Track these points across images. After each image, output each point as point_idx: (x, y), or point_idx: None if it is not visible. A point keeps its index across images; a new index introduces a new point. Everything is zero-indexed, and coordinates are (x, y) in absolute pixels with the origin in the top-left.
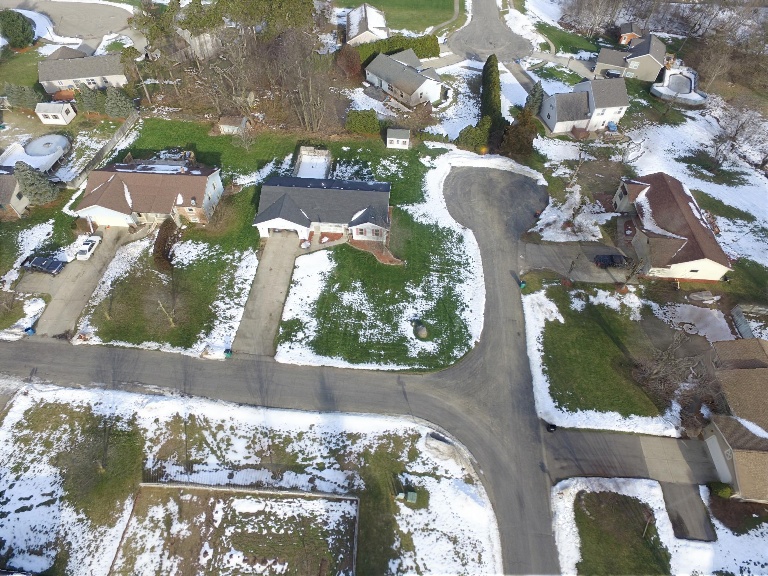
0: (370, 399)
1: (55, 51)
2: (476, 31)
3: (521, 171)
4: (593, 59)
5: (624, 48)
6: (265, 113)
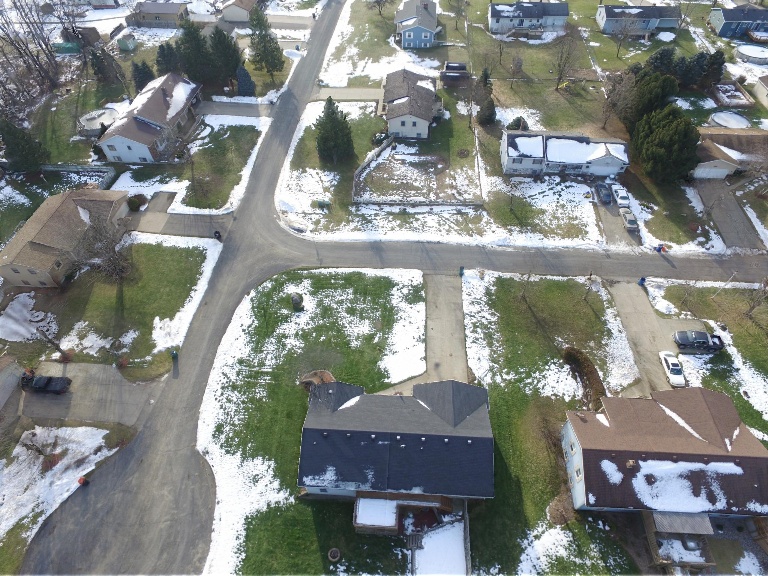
0: (344, 249)
1: None
2: None
3: None
4: None
5: None
6: None
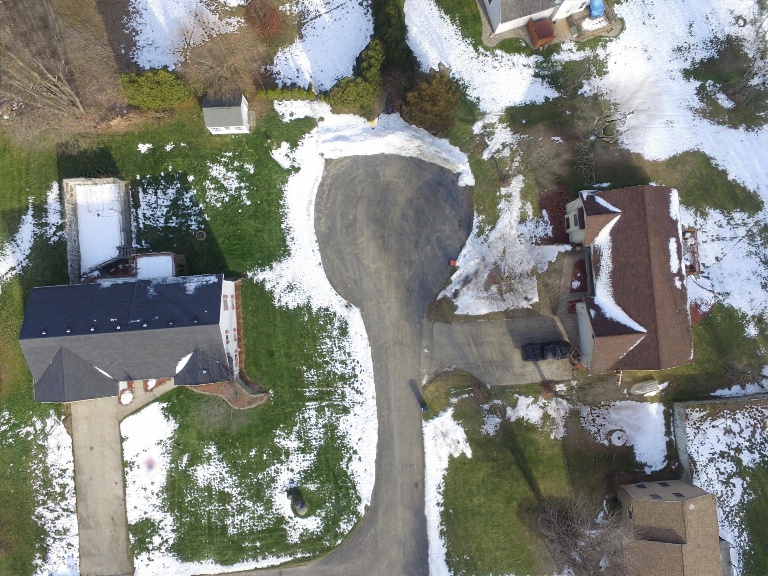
0: None
1: None
2: None
3: (434, 159)
4: None
5: None
6: None
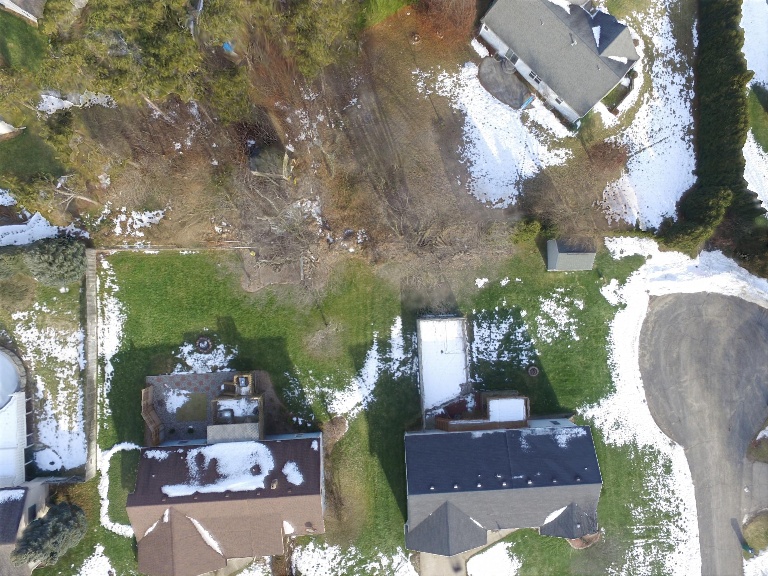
0: None
1: None
2: None
3: (757, 300)
4: None
5: None
6: (320, 197)
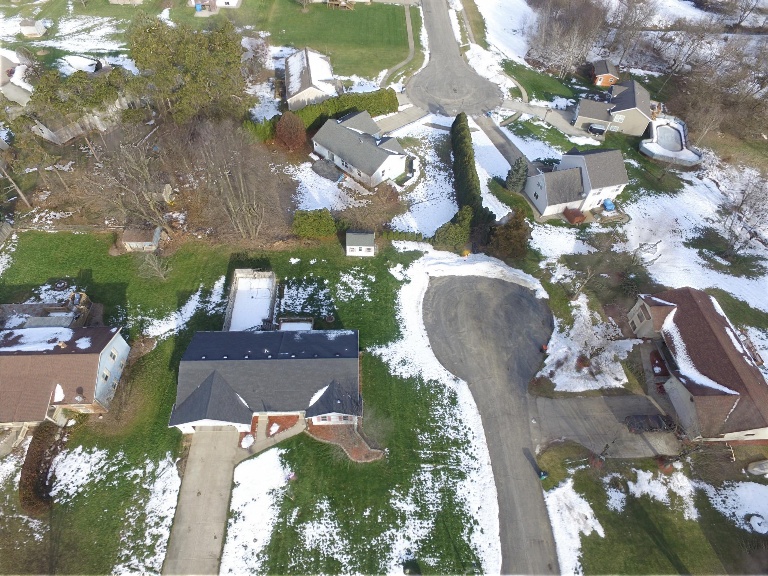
0: None
1: None
2: (437, 74)
3: (514, 279)
4: (571, 108)
5: (601, 91)
6: (187, 211)
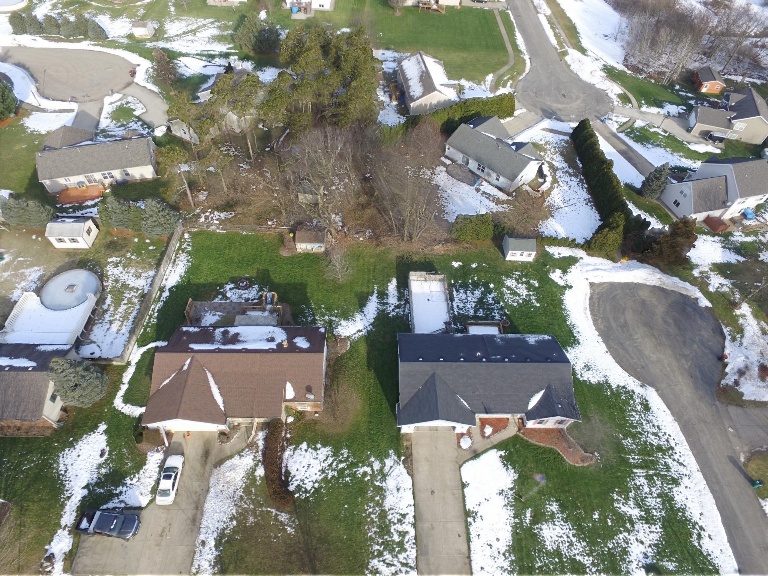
0: None
1: (53, 133)
2: (542, 79)
3: (675, 287)
4: (683, 115)
5: (707, 98)
6: (341, 213)
